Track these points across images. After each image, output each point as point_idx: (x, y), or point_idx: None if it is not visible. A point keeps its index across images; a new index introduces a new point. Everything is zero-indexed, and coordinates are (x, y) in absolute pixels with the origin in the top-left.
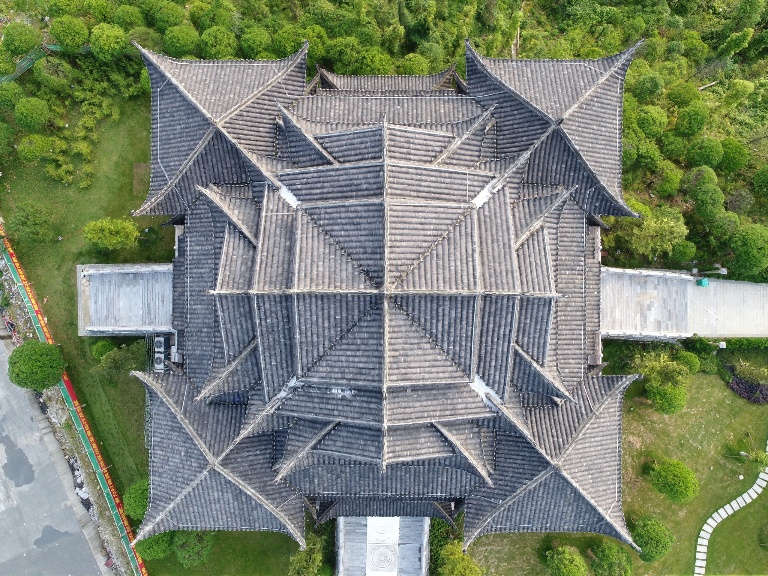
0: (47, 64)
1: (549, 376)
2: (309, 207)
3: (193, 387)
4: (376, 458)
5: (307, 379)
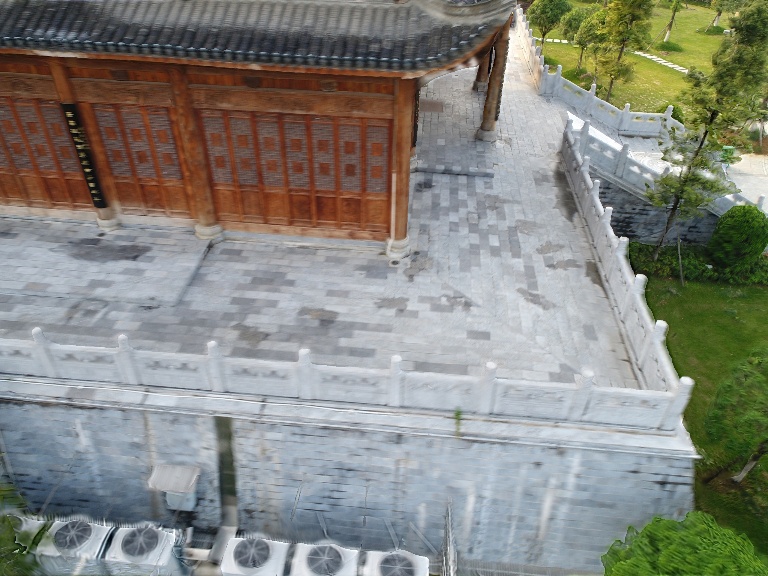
0: None
1: None
2: None
3: None
4: None
5: None
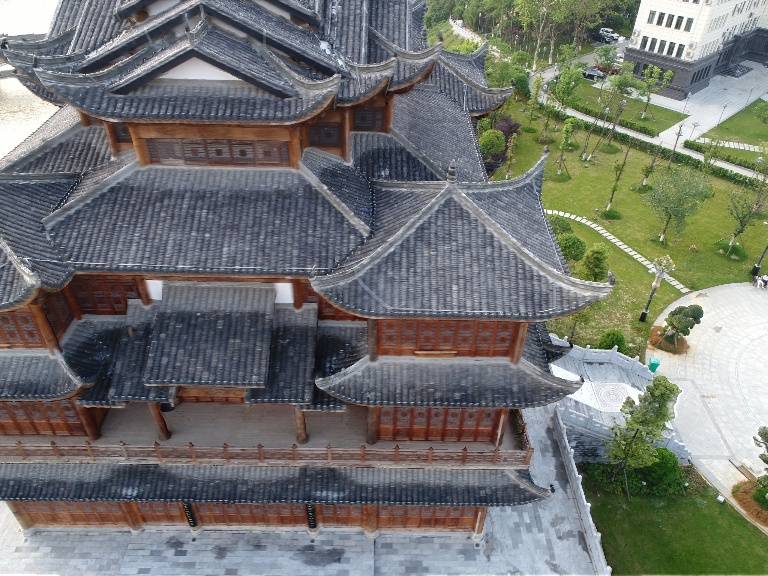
0: None
1: None
2: (120, 0)
3: (348, 258)
4: (406, 4)
5: (316, 7)
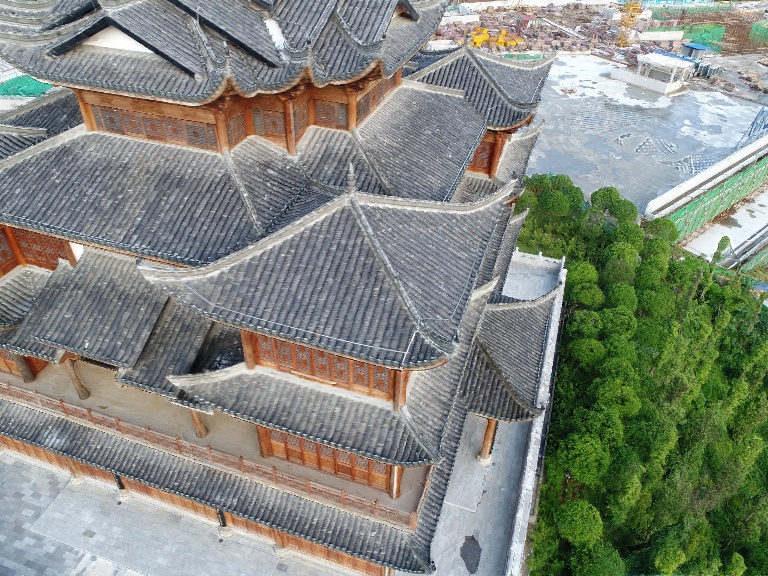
0: (599, 217)
1: (28, 51)
2: None
3: None
4: None
5: None
